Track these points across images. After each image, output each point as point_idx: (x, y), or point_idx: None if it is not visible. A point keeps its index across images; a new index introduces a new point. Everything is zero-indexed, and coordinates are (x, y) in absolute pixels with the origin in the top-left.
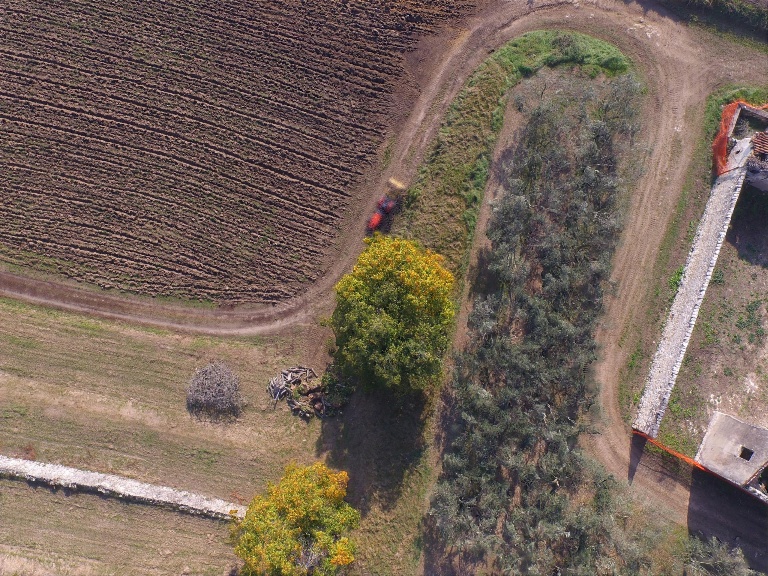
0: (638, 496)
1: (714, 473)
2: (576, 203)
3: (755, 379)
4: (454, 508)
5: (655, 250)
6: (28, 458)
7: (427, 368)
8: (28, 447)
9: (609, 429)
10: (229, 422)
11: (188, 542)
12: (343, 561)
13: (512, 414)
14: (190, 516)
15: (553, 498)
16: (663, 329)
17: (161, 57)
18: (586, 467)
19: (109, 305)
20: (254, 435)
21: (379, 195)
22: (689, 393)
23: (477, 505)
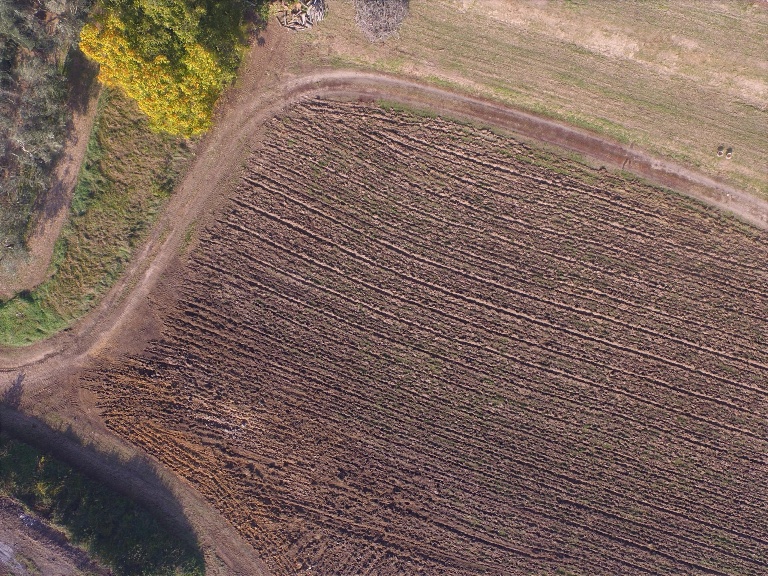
0: None
1: None
2: None
3: None
4: None
5: None
6: None
7: None
8: None
9: None
10: None
11: None
12: None
13: None
14: None
15: None
16: None
17: (413, 359)
18: None
19: (484, 113)
20: None
21: (201, 197)
22: None
23: None
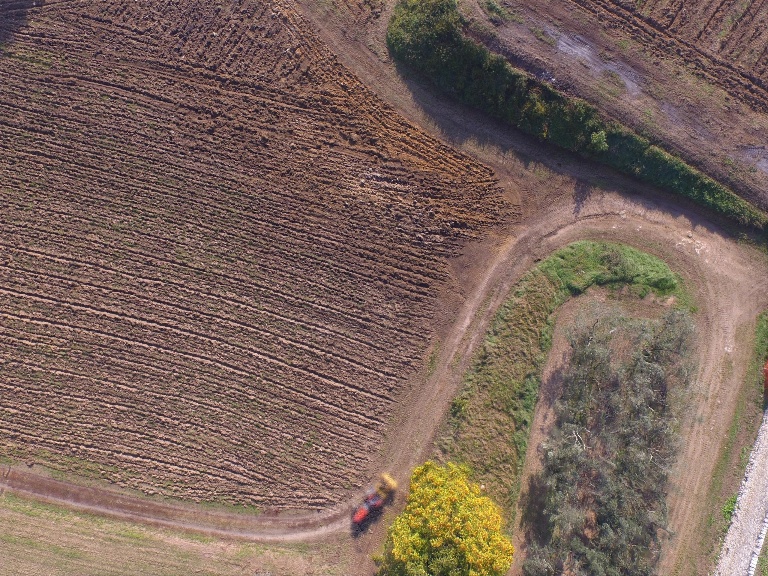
0: None
1: None
2: (633, 451)
3: None
4: None
5: (708, 477)
6: None
7: None
8: None
9: None
10: None
11: None
12: None
13: None
14: None
15: None
16: (717, 561)
17: (204, 260)
18: None
19: (153, 511)
20: None
21: (424, 401)
22: None
23: None
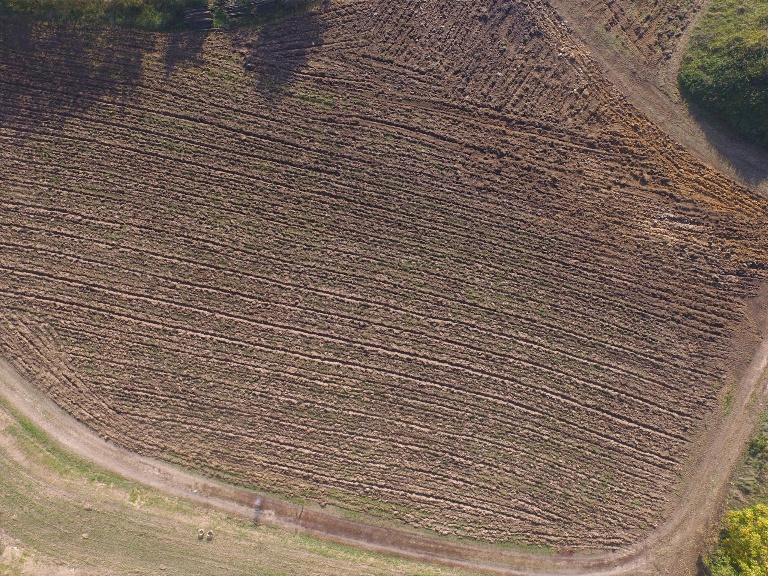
0: None
1: None
2: None
3: None
4: None
5: None
6: None
7: None
8: None
9: None
10: None
11: None
12: None
13: None
14: None
15: None
16: None
17: (494, 300)
18: None
19: (446, 551)
20: None
21: (721, 441)
22: None
23: None
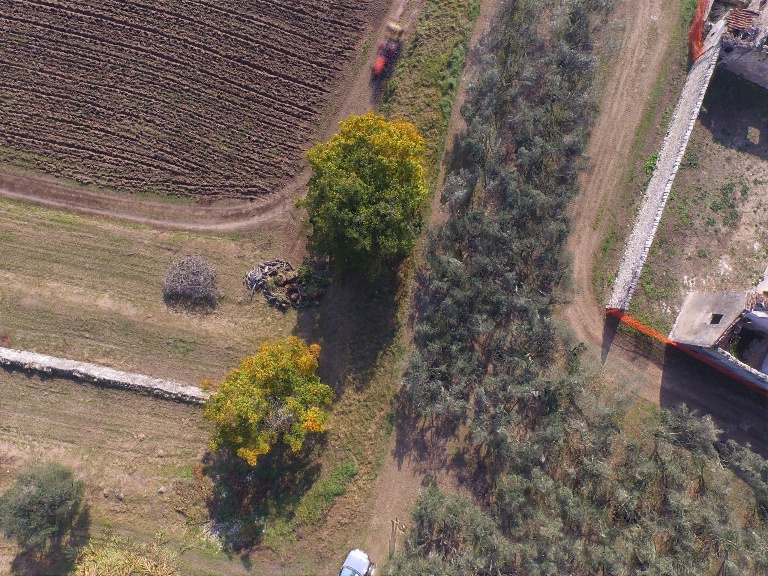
0: (611, 375)
1: (686, 348)
2: (549, 78)
3: (729, 261)
4: (425, 375)
5: (630, 136)
6: (4, 345)
7: (398, 235)
8: (4, 335)
9: (583, 310)
10: (205, 314)
11: (163, 426)
12: (313, 428)
13: (483, 283)
14: (165, 401)
15: (523, 362)
16: (638, 212)
17: None
18: (559, 346)
19: (87, 201)
20: (230, 325)
21: (357, 90)
22: (663, 274)
23: (447, 372)
